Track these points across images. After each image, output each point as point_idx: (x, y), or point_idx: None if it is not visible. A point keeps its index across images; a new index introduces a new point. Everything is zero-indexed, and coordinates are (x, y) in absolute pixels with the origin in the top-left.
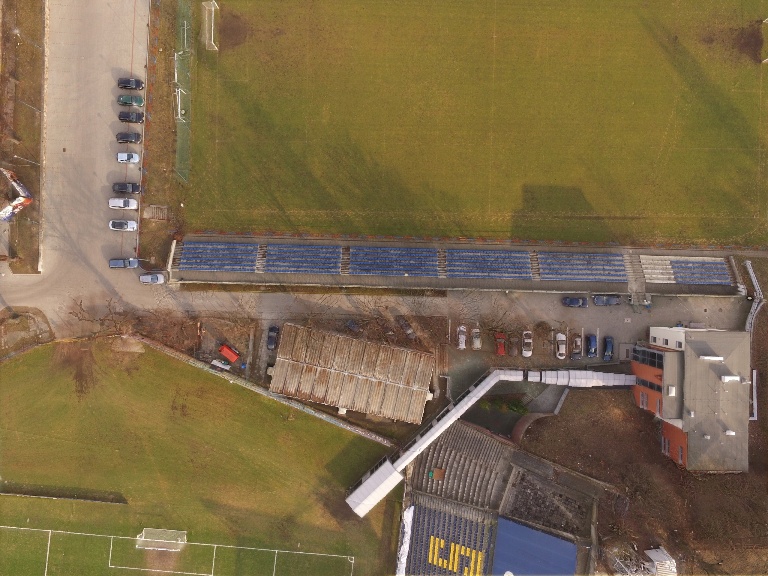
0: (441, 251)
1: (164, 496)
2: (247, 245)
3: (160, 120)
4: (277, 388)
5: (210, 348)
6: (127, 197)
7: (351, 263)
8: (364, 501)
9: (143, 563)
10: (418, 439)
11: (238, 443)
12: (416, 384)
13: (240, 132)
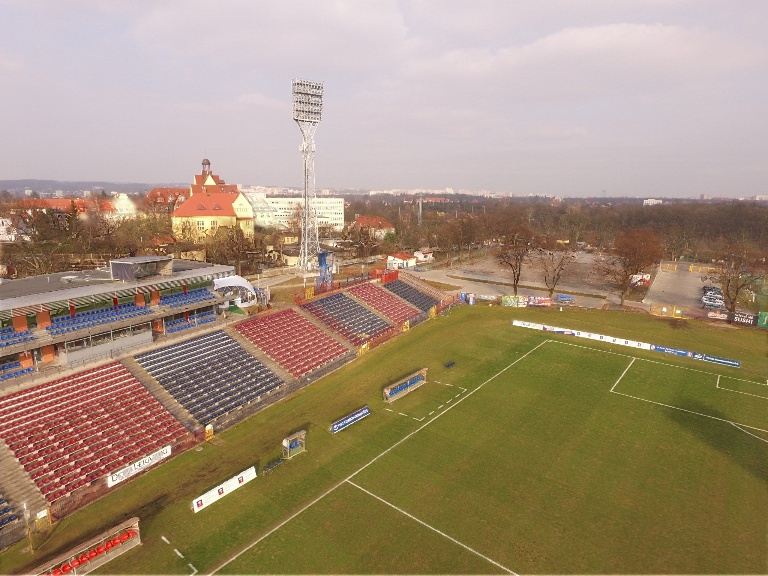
0: None
1: None
2: None
3: None
4: None
5: None
6: None
7: None
8: None
9: None
10: None
11: None
12: None
13: None
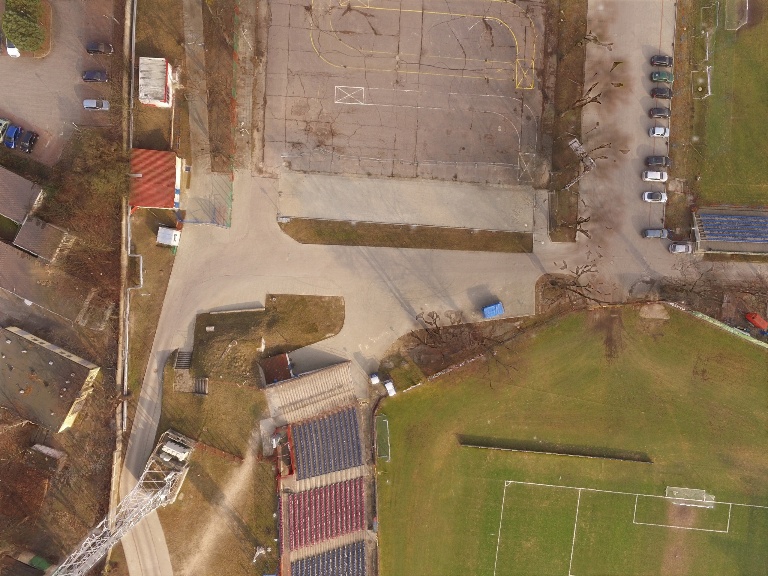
0: None
1: (685, 456)
2: (759, 218)
3: (682, 96)
4: None
5: (730, 316)
6: (661, 170)
7: None
8: None
9: (665, 520)
10: None
11: (753, 407)
12: None
13: (753, 109)
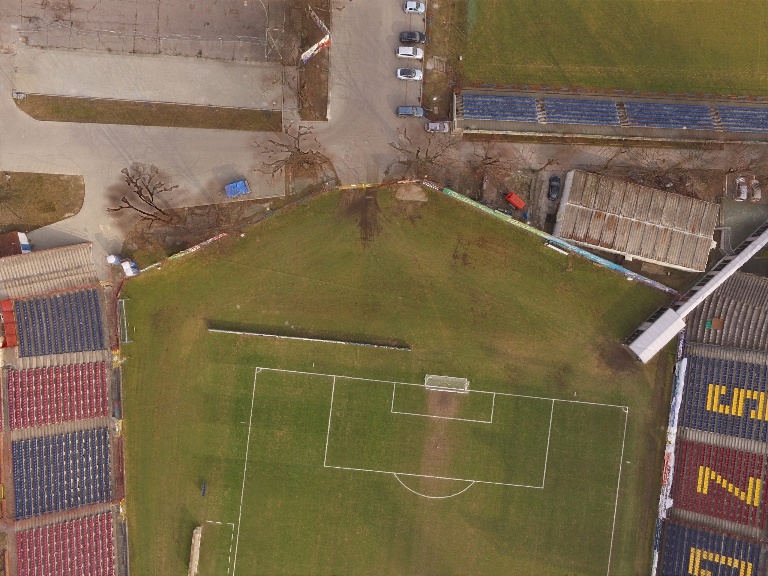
0: (712, 108)
1: (445, 344)
2: (524, 99)
3: None
4: (567, 233)
5: (491, 198)
6: (415, 46)
7: (629, 116)
8: (649, 346)
9: (424, 409)
10: (700, 287)
11: (517, 293)
12: (701, 232)
13: None
